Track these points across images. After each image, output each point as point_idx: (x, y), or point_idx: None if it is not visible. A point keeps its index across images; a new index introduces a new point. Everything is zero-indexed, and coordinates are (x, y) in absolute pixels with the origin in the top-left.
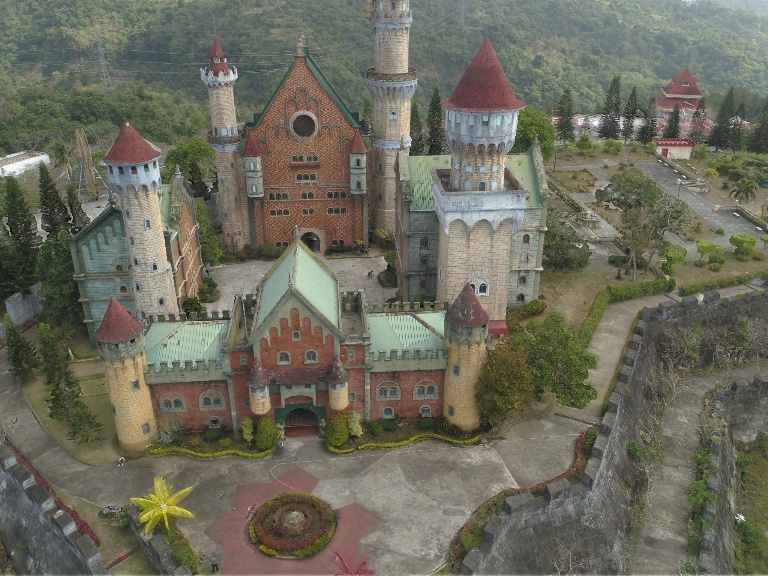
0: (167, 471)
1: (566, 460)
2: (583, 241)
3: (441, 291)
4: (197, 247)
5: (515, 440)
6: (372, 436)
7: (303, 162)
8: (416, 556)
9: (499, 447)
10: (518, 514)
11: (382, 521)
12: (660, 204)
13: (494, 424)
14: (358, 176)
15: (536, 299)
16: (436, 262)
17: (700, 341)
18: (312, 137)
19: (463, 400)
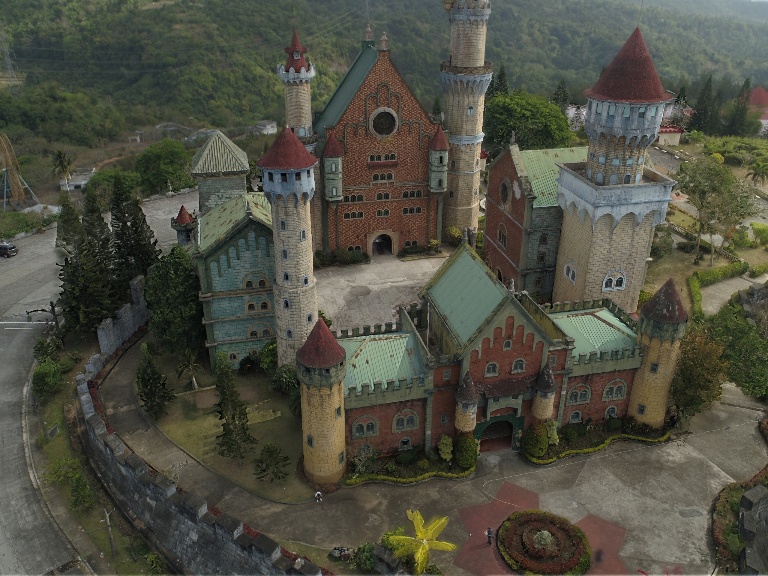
0: (374, 502)
1: (761, 449)
2: (667, 229)
3: (570, 288)
4: None
5: (701, 433)
6: (565, 443)
7: (381, 161)
8: (683, 563)
9: (691, 442)
10: (756, 508)
11: (628, 531)
12: (738, 190)
13: (677, 419)
14: (440, 174)
15: (642, 290)
16: (553, 258)
17: None
18: (391, 135)
19: (657, 398)
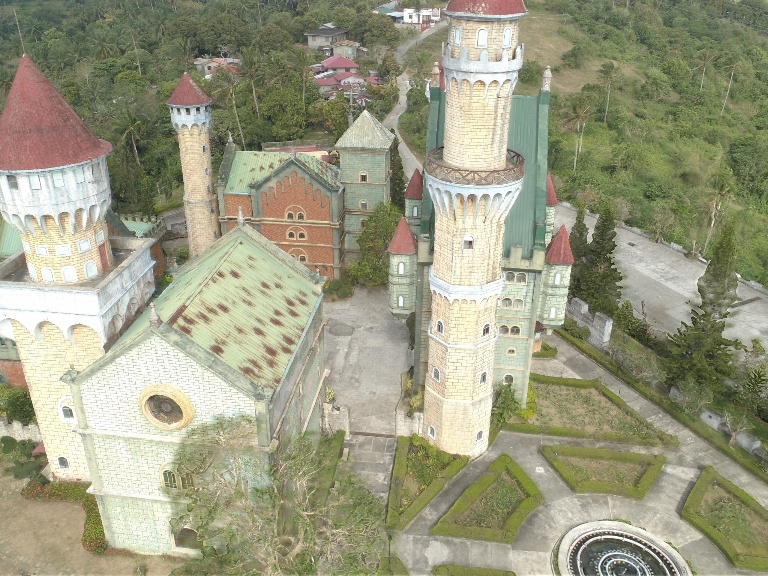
0: None
1: None
2: None
3: None
4: (332, 244)
5: None
6: None
7: None
8: None
9: None
10: None
11: None
12: None
13: None
14: None
15: None
16: None
17: None
18: None
19: None
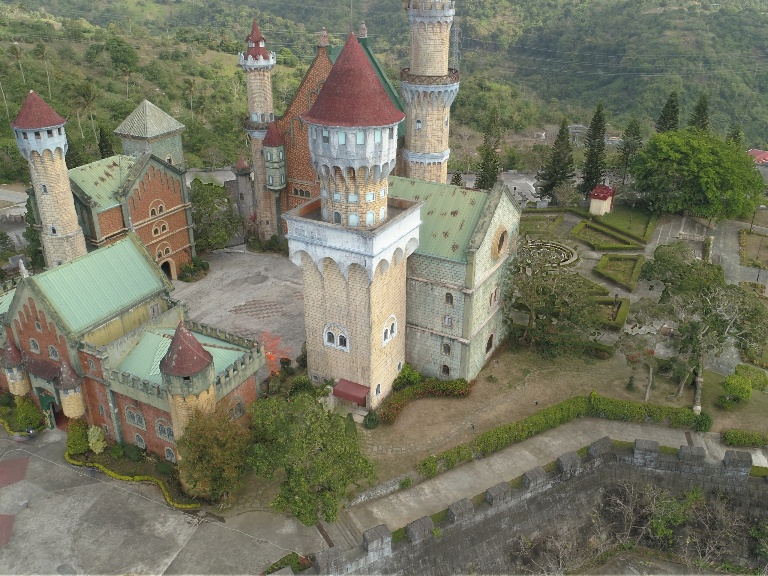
0: None
1: None
2: (580, 324)
3: None
4: (186, 225)
5: (230, 528)
6: None
7: None
8: None
9: (204, 527)
10: None
11: (5, 545)
12: None
13: None
14: None
15: (463, 378)
16: None
17: (692, 516)
18: None
19: None
